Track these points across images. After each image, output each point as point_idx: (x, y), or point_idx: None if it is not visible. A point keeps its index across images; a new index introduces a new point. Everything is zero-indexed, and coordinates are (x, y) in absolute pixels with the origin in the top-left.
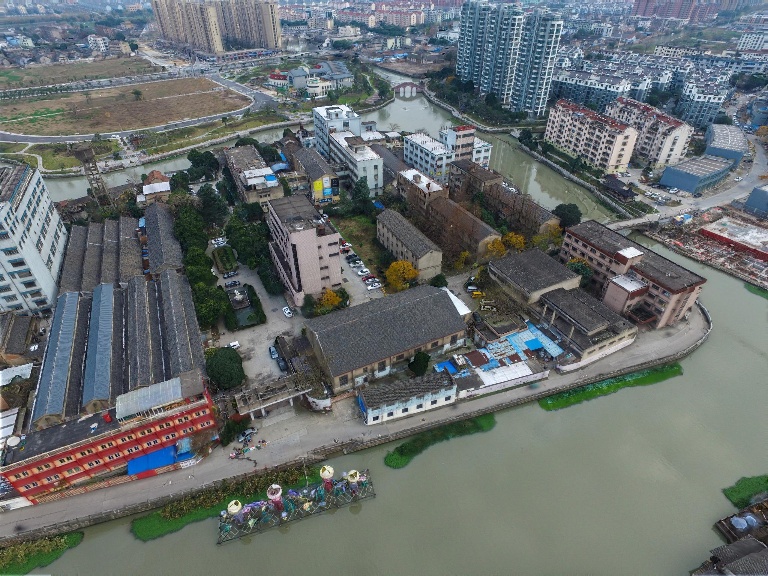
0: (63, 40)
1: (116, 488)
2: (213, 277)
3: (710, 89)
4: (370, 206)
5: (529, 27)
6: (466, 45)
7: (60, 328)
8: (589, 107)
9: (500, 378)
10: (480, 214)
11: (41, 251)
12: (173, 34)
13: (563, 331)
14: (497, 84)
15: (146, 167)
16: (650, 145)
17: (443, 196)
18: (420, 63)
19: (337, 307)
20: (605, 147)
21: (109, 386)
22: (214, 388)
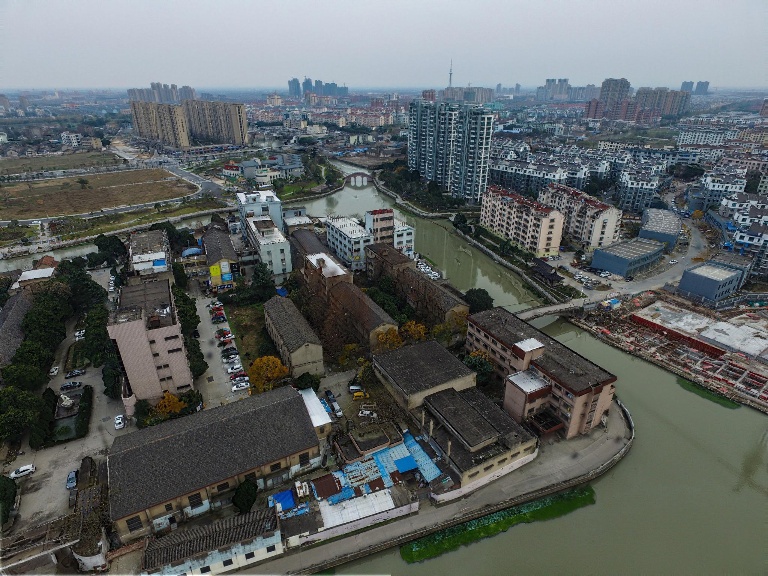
0: (41, 137)
1: None
2: (38, 378)
3: (642, 176)
4: (269, 292)
5: (462, 120)
6: (412, 139)
7: None
8: (527, 193)
9: (349, 515)
10: (382, 300)
11: None
12: (147, 132)
13: (442, 446)
14: (440, 173)
15: (56, 253)
16: (581, 228)
17: (347, 281)
18: (378, 156)
19: (181, 415)
20: (533, 230)
21: None
22: None
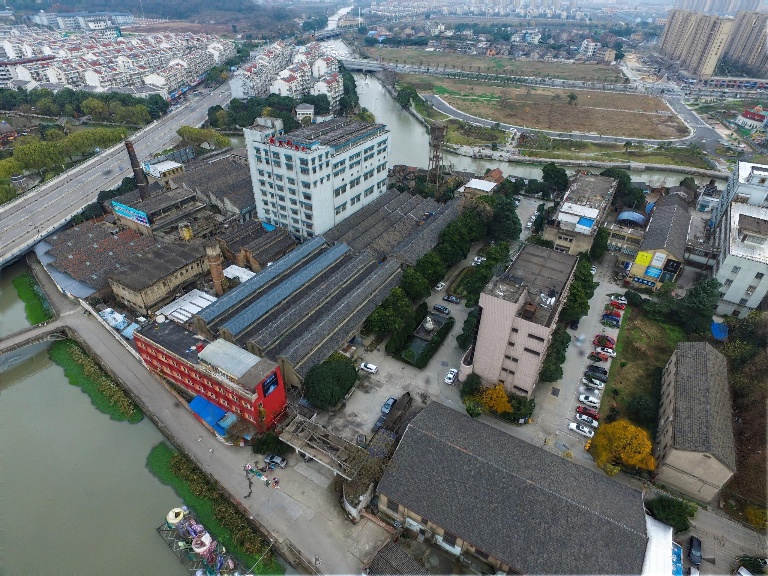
0: (566, 42)
1: (181, 407)
2: (422, 291)
3: None
4: (699, 323)
5: None
6: None
7: (283, 260)
8: None
9: None
10: None
11: (338, 196)
12: (670, 49)
13: None
14: None
15: (511, 165)
16: None
17: None
18: None
19: (502, 415)
20: None
21: (246, 326)
22: (301, 393)
